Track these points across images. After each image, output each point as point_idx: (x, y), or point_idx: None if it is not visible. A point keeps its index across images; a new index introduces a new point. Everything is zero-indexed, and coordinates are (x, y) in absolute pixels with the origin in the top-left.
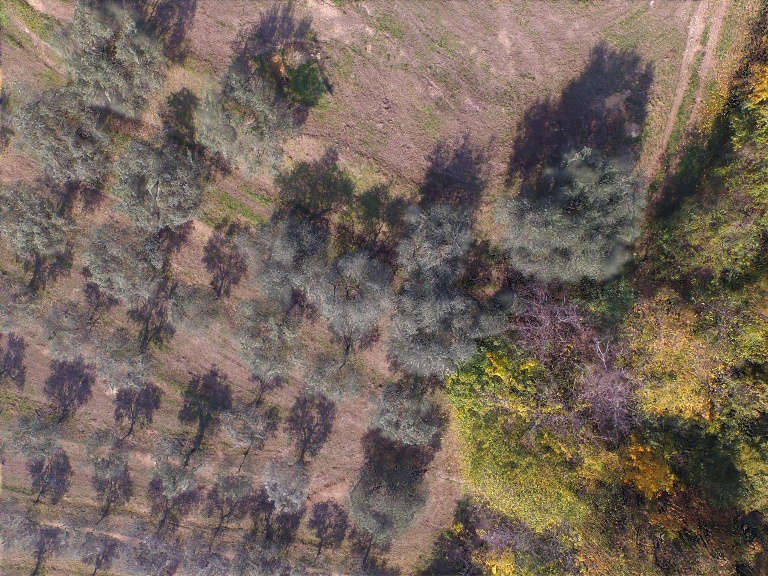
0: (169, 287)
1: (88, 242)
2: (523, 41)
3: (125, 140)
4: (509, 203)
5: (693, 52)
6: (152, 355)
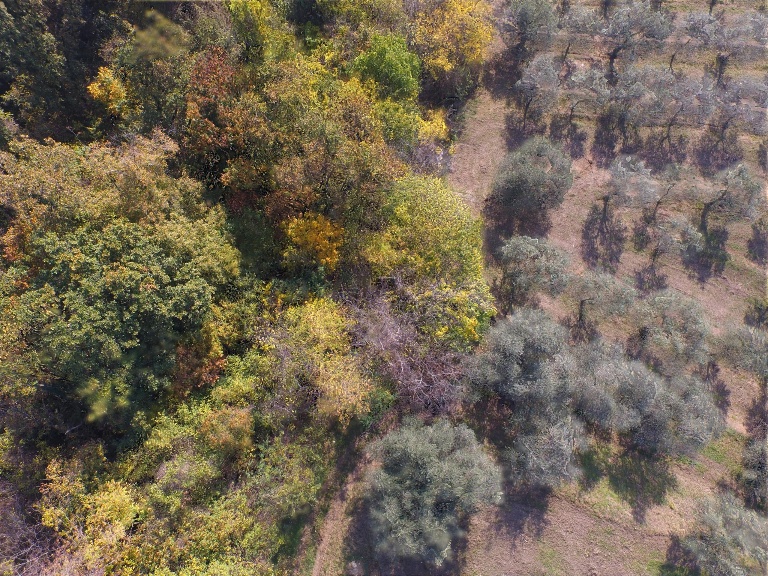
0: (759, 363)
1: None
2: None
3: None
4: None
5: None
6: (763, 294)
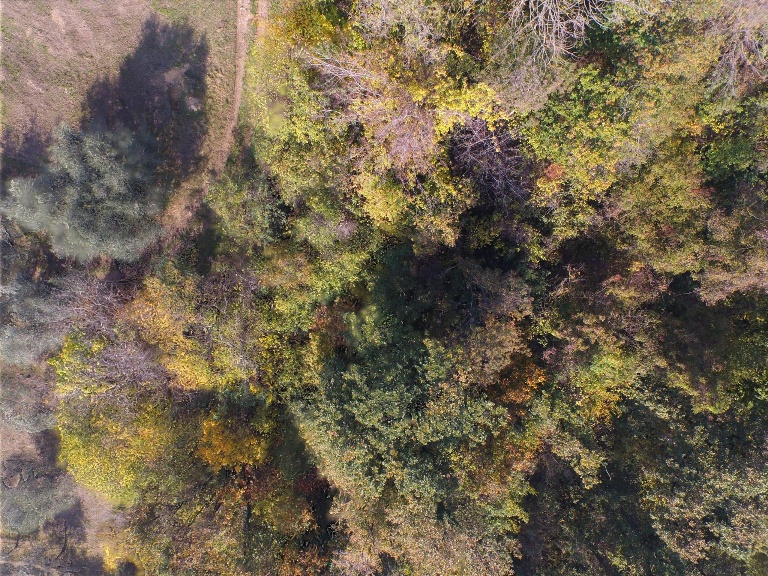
0: None
1: None
2: (76, 19)
3: None
4: None
5: (246, 21)
6: None
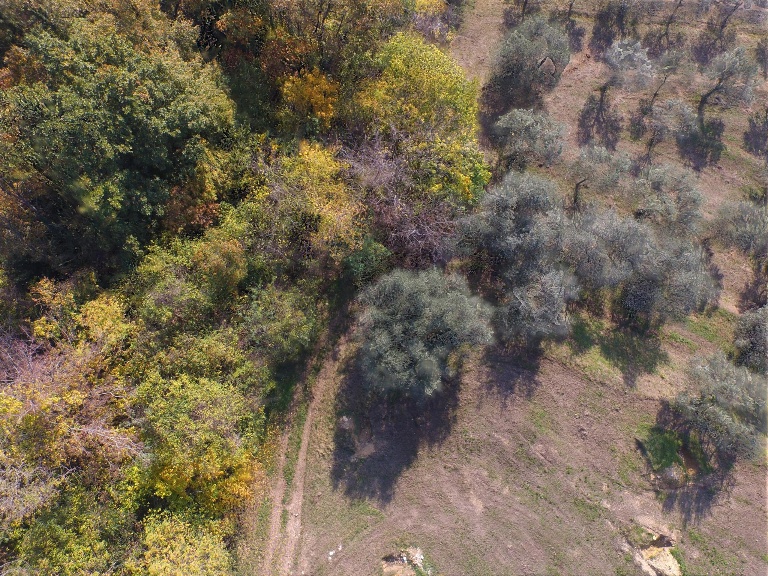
0: (752, 248)
1: None
2: (459, 503)
3: None
4: None
5: (294, 503)
6: (759, 183)
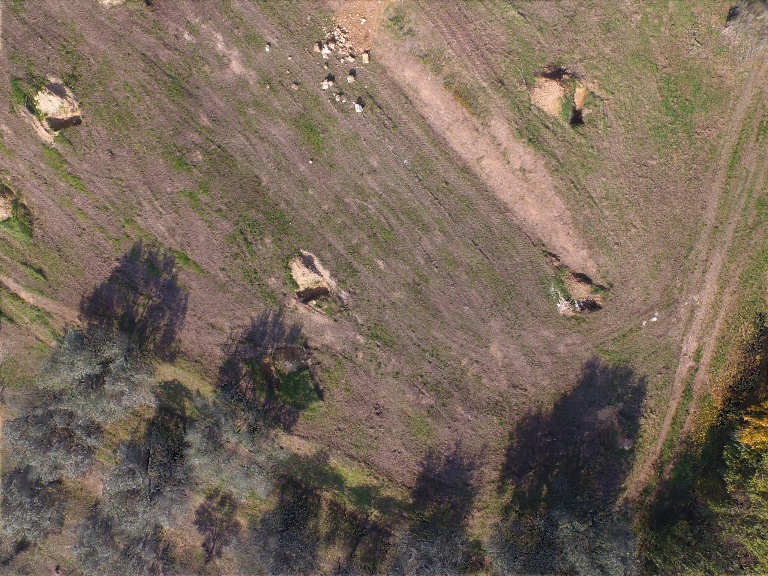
0: (161, 548)
1: (79, 504)
2: (515, 354)
3: (116, 411)
4: (499, 561)
5: (686, 367)
6: None
